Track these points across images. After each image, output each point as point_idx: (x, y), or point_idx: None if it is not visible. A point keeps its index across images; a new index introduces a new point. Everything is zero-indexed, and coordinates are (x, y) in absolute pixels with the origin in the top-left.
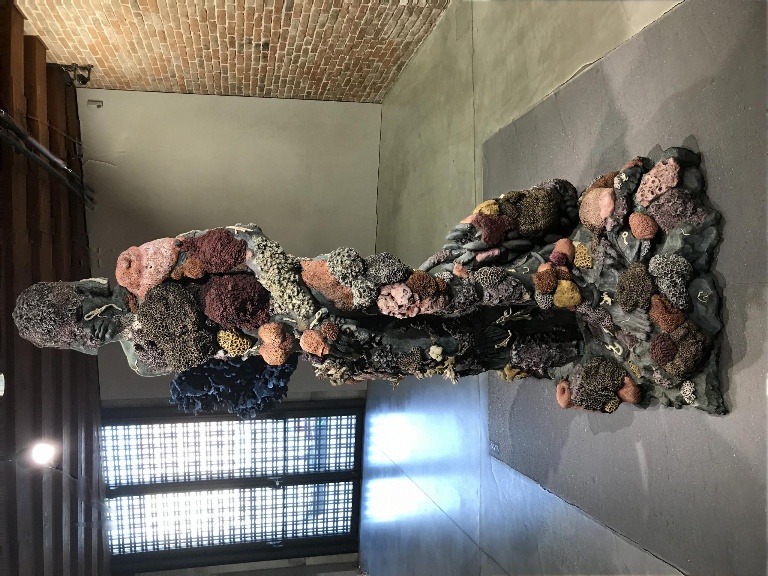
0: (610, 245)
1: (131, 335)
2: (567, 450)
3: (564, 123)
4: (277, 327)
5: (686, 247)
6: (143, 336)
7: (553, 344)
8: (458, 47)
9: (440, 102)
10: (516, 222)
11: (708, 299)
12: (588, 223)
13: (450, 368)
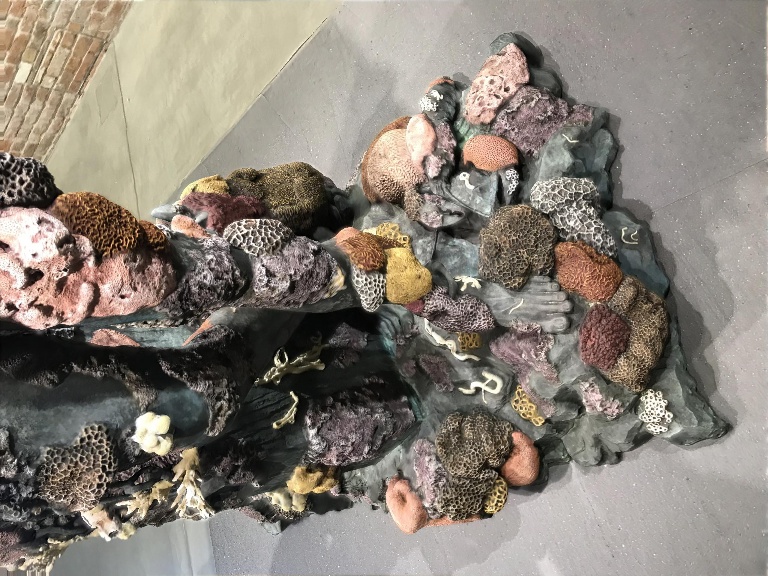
0: (443, 198)
1: None
2: None
3: (287, 123)
4: None
5: (578, 163)
6: None
7: (376, 404)
8: (104, 131)
9: None
10: (264, 204)
11: (638, 237)
12: (391, 182)
13: (191, 478)
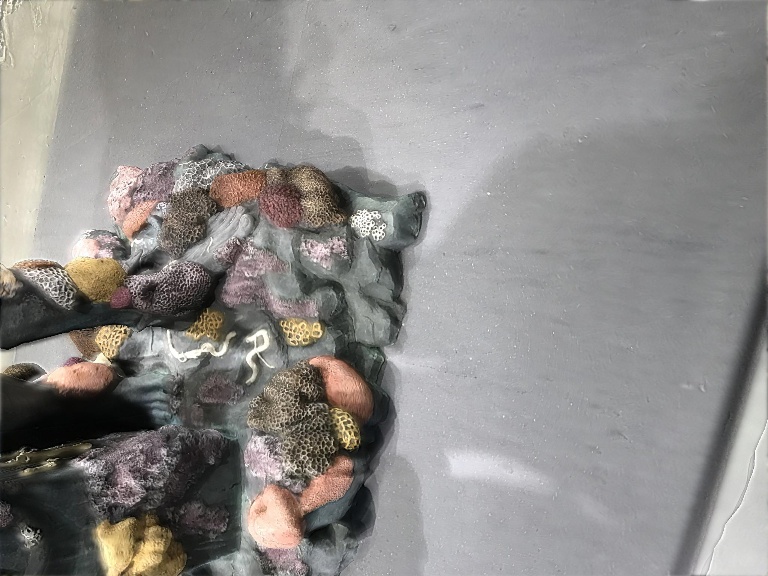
0: None
1: None
2: None
3: None
4: None
5: None
6: None
7: None
8: None
9: None
10: None
11: (271, 166)
12: None
13: None
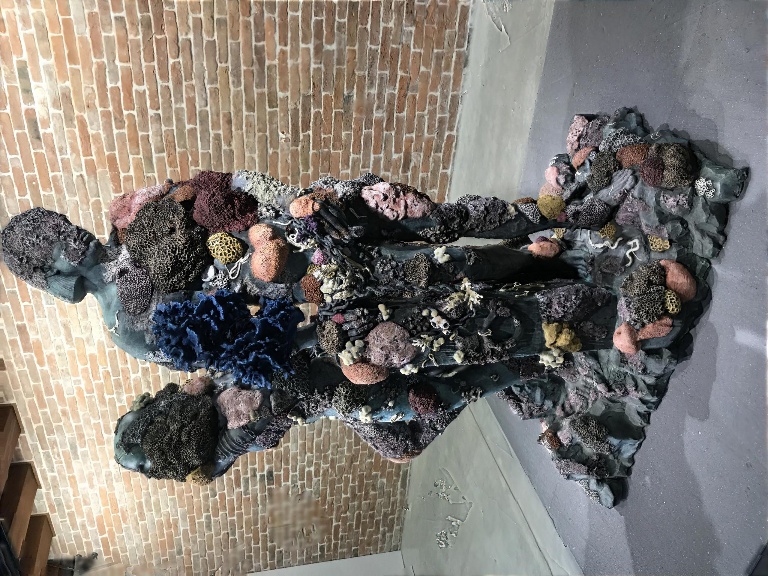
0: None
1: (116, 269)
2: (706, 495)
3: None
4: (267, 225)
5: None
6: (129, 260)
7: None
8: None
9: (446, 457)
10: None
11: (660, 134)
12: None
13: (466, 281)
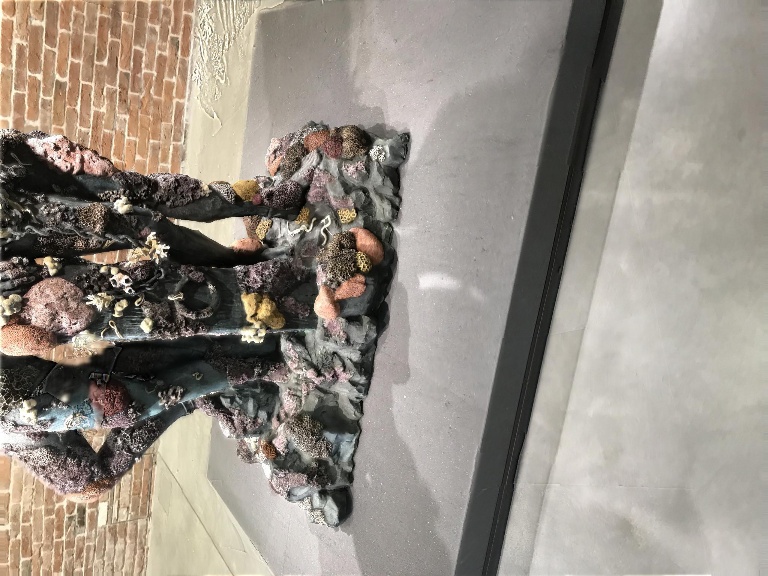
0: None
1: None
2: (418, 458)
3: None
4: None
5: None
6: None
7: None
8: (171, 517)
9: None
10: None
11: None
12: None
13: None
